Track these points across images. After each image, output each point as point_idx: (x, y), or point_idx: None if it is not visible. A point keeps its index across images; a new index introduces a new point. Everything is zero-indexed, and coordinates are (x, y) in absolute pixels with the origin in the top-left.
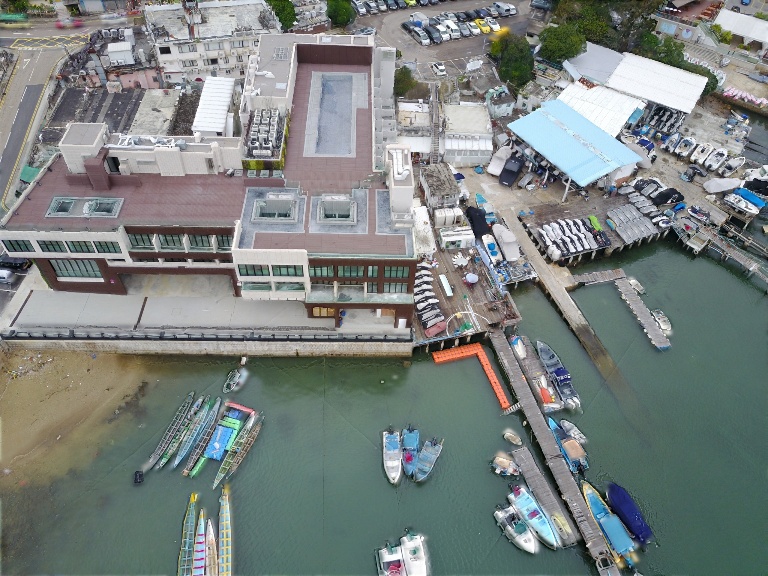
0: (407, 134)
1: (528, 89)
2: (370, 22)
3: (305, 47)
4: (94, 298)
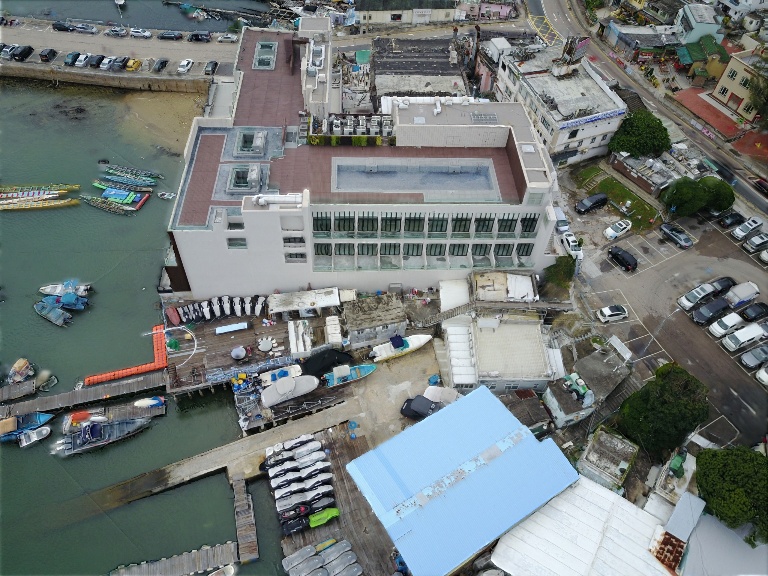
0: None
1: (612, 440)
2: (716, 243)
3: None
4: None
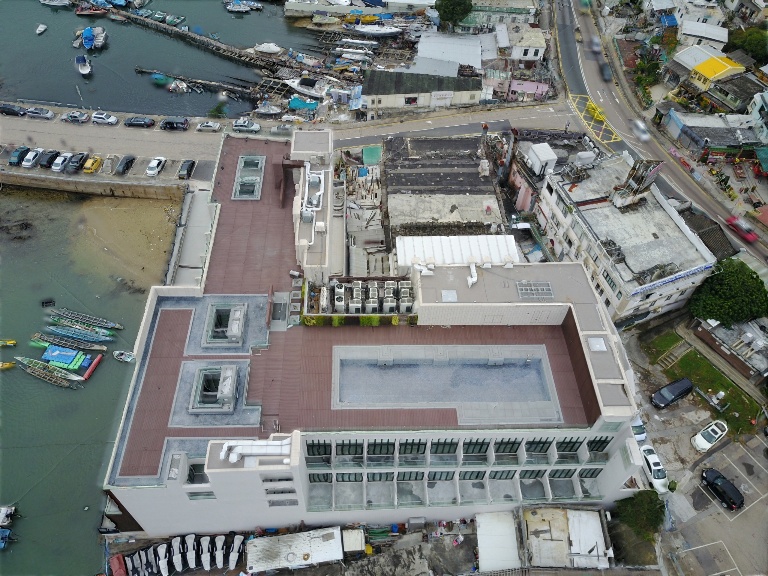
0: None
1: None
2: None
3: (572, 320)
4: None
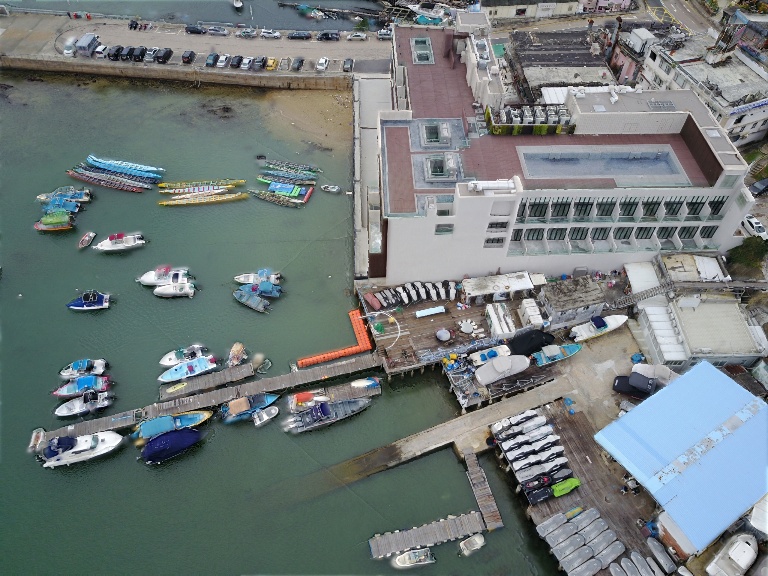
0: (658, 270)
1: None
2: None
3: (692, 122)
4: (388, 105)
